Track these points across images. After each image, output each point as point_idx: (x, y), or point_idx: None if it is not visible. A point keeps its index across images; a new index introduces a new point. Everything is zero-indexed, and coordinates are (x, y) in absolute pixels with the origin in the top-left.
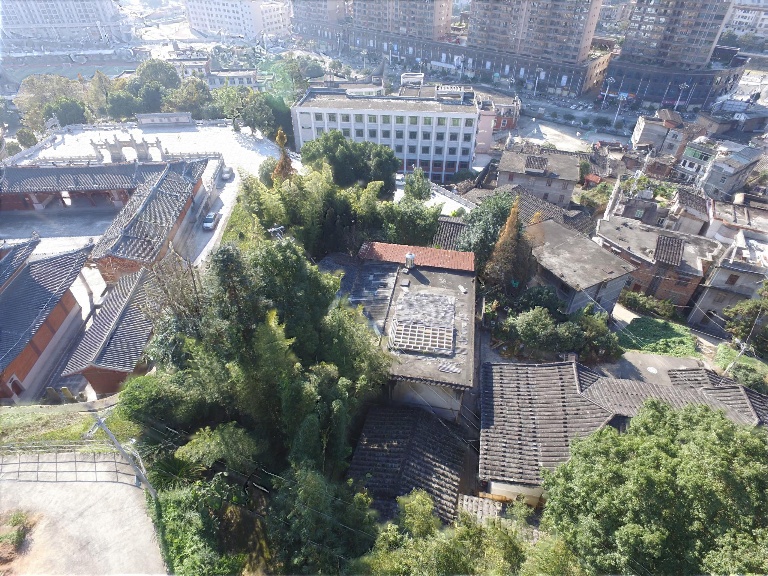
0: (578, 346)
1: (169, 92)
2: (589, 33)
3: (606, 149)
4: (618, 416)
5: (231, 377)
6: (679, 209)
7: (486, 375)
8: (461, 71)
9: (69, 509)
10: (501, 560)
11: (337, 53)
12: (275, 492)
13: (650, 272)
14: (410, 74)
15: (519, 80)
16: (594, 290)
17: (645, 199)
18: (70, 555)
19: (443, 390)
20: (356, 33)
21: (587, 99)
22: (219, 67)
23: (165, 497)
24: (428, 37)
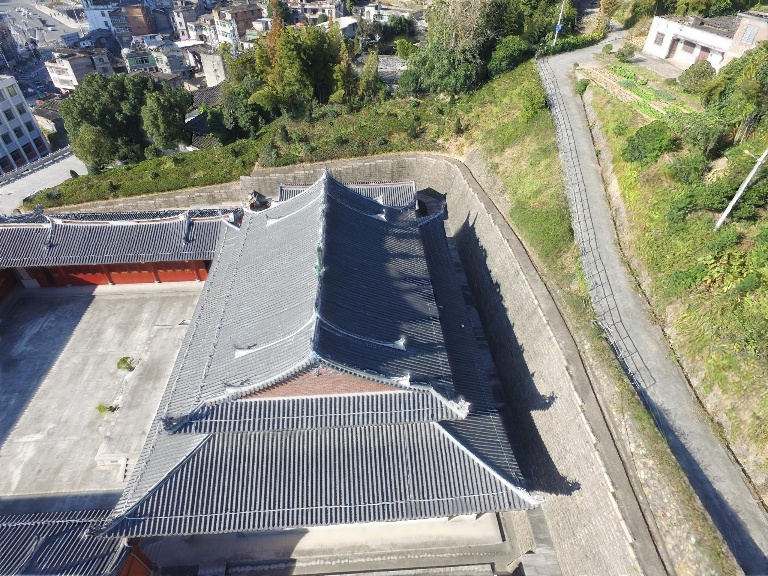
0: None
1: None
2: None
3: None
4: None
5: (520, 3)
6: None
7: None
8: None
9: (563, 67)
10: None
11: None
12: None
13: None
14: None
15: None
16: None
17: None
18: None
19: None
20: None
21: None
22: None
23: None
24: None
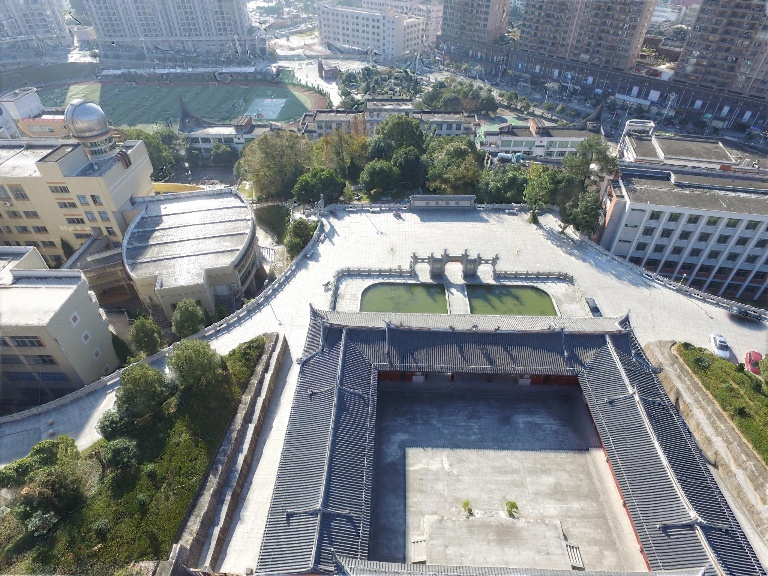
0: None
1: (429, 161)
2: None
3: None
4: None
5: None
6: None
7: None
8: (666, 111)
9: None
10: None
11: (492, 77)
12: None
13: None
14: (635, 121)
15: (737, 124)
16: None
17: None
18: None
19: None
20: (519, 56)
21: None
22: (419, 108)
23: None
24: (618, 67)
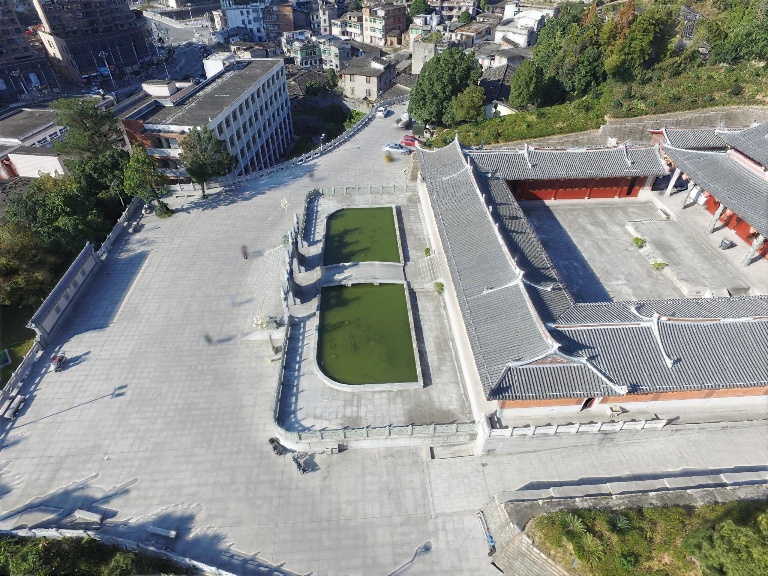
0: None
1: None
2: None
3: None
4: None
5: None
6: (461, 37)
7: None
8: None
9: None
10: None
11: None
12: None
13: None
14: None
15: None
16: None
17: None
18: None
19: None
20: None
21: (72, 89)
22: None
23: None
24: None
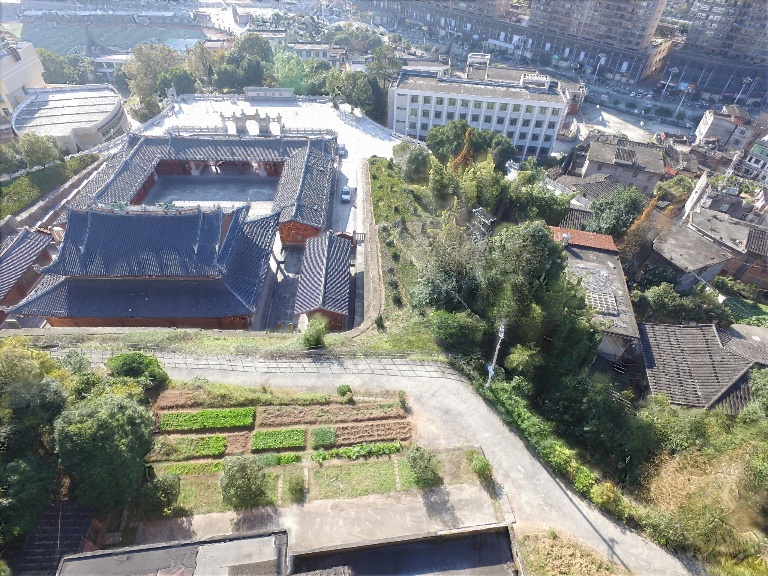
0: (698, 316)
1: (268, 66)
2: (655, 20)
3: (671, 140)
4: (758, 363)
5: (536, 313)
6: (764, 206)
7: (641, 331)
8: (521, 52)
9: (423, 392)
10: (724, 433)
11: (392, 25)
12: (551, 391)
13: (739, 260)
14: (476, 54)
15: None
16: (697, 272)
17: (731, 195)
18: (440, 417)
19: (614, 340)
20: (413, 6)
21: (646, 87)
22: (295, 39)
23: (494, 386)
24: (488, 15)
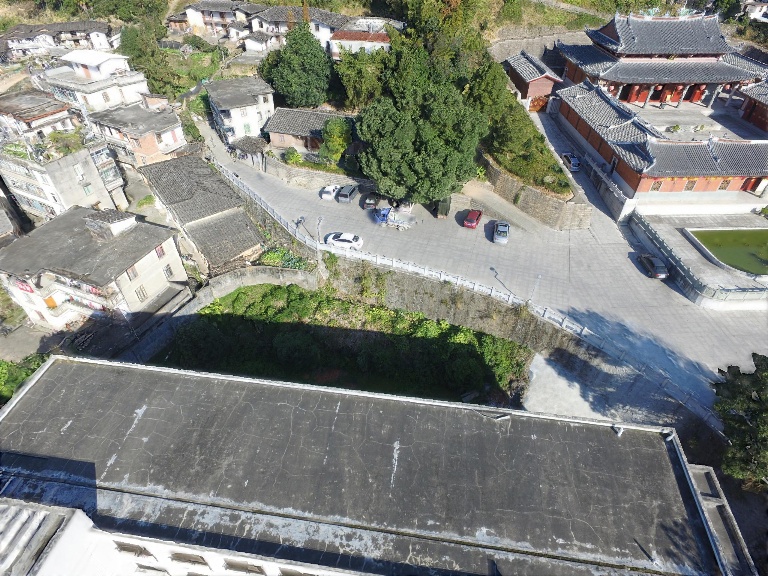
0: None
1: None
2: None
3: None
4: None
5: None
6: None
7: None
8: None
9: None
10: None
11: None
12: None
13: None
14: None
15: None
16: None
17: None
18: None
19: None
20: None
21: None
22: None
23: None
24: None
